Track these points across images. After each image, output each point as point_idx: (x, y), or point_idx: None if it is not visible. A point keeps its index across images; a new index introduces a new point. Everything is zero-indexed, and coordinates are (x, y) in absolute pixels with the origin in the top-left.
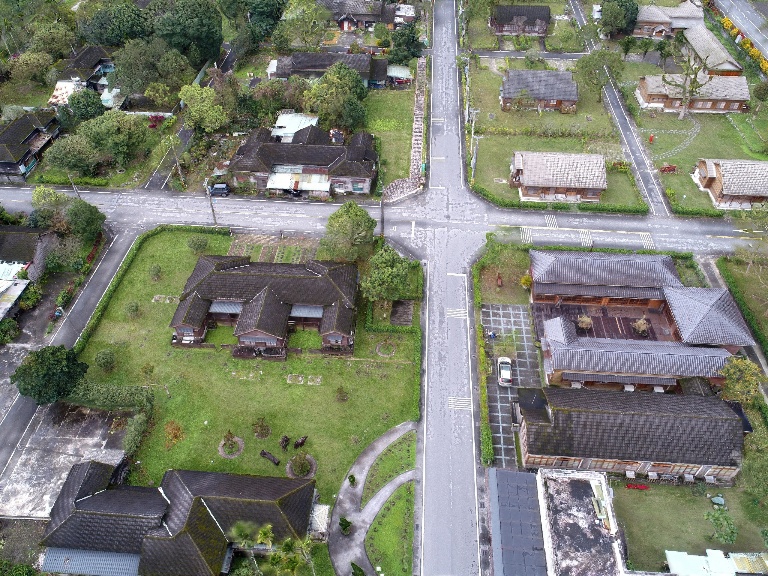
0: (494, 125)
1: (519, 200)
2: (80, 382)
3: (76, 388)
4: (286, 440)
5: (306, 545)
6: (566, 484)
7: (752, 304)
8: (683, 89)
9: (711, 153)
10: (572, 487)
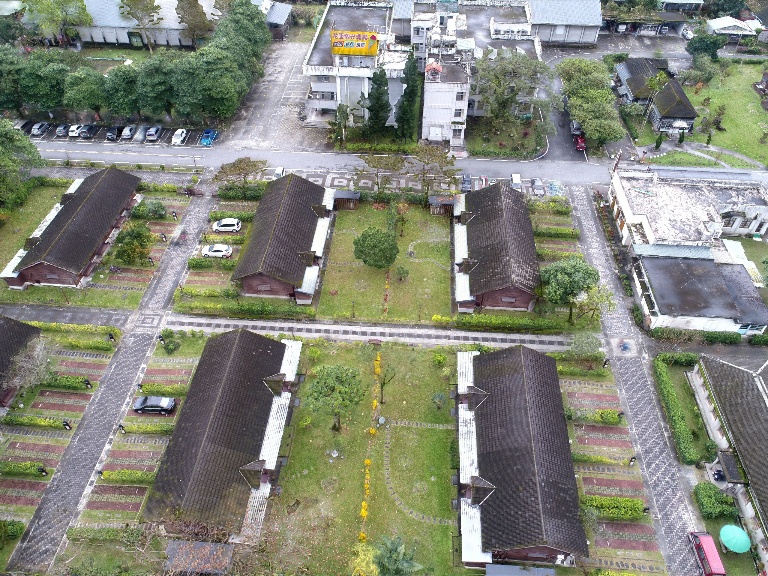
0: None
1: None
2: (705, 54)
3: (701, 54)
4: (718, 122)
5: (663, 77)
6: (759, 197)
7: None
8: None
9: None
10: (759, 199)
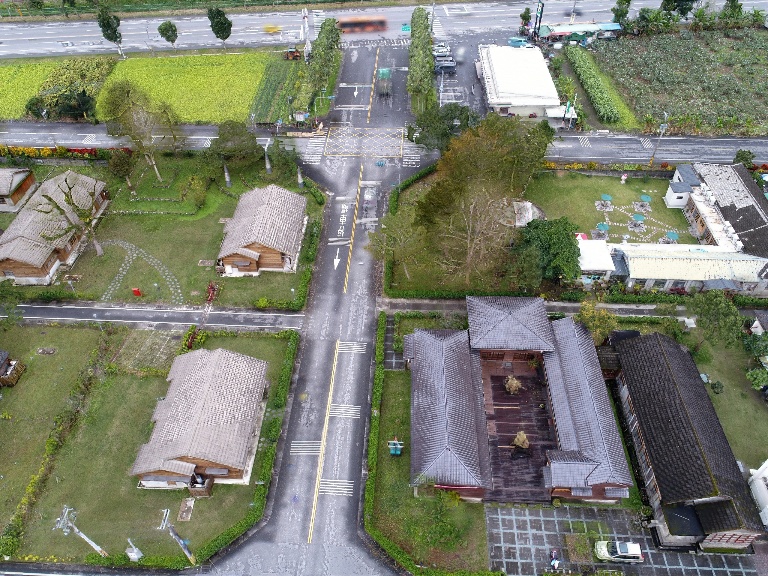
0: (2, 500)
1: (256, 485)
2: None
3: None
4: None
5: None
6: None
7: (453, 288)
8: (76, 228)
9: (185, 247)
10: None
